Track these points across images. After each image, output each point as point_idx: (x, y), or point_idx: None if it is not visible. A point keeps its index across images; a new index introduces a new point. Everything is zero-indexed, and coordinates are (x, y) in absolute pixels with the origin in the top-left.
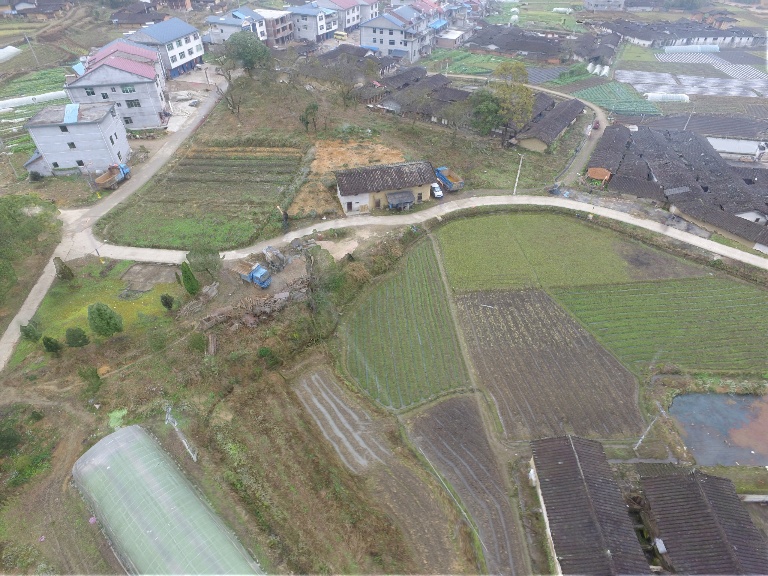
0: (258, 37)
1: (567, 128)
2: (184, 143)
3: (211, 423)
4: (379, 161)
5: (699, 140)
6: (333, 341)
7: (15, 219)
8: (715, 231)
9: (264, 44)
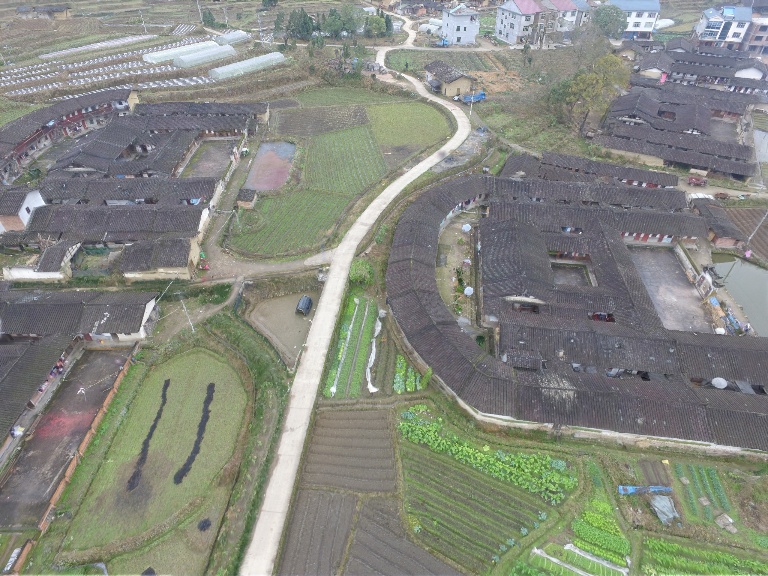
0: (621, 12)
1: (672, 168)
2: (492, 50)
3: (288, 68)
4: (493, 84)
5: (675, 218)
6: (330, 87)
7: (358, 17)
8: None
9: (617, 18)
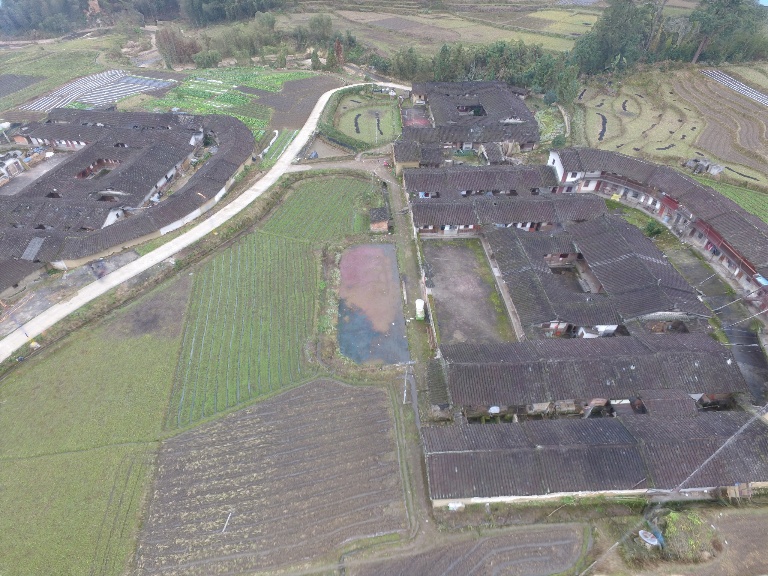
0: None
1: None
2: None
3: None
4: None
5: None
6: None
7: None
8: (123, 248)
9: None
